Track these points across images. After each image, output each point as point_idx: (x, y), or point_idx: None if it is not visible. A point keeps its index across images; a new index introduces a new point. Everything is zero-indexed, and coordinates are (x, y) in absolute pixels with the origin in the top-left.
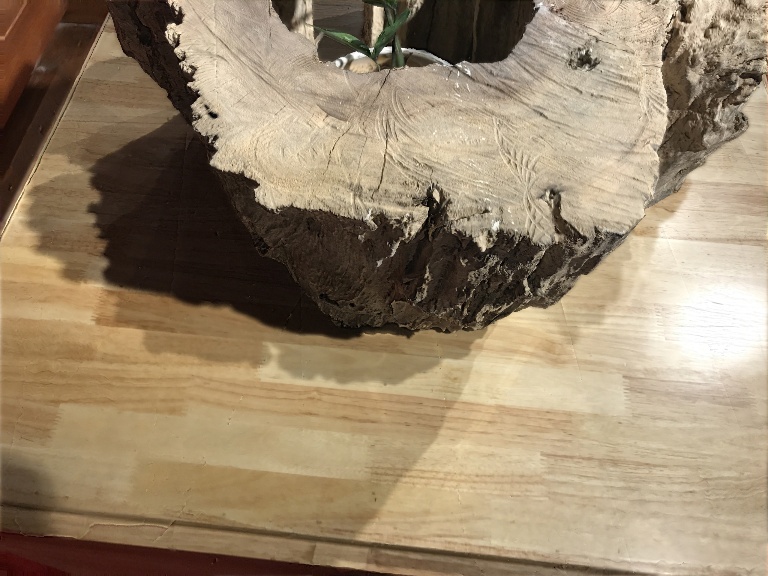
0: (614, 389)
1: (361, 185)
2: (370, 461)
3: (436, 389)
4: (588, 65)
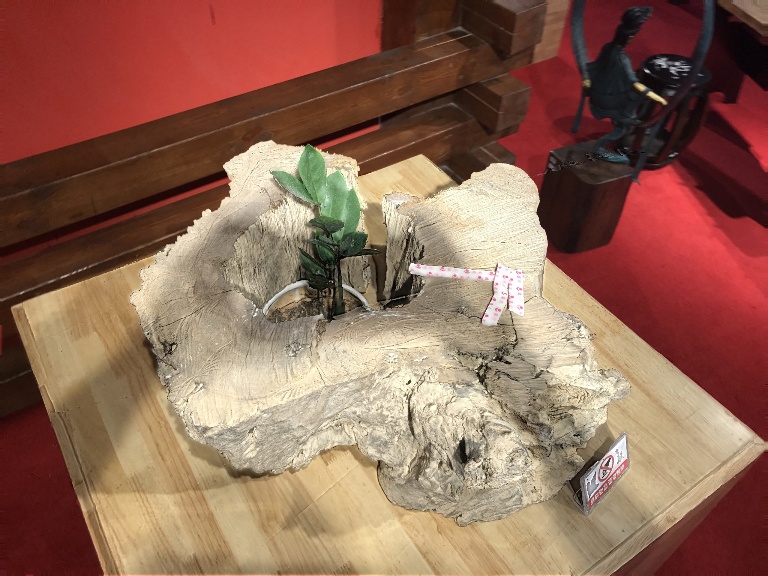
0: (265, 570)
1: (161, 320)
2: (139, 472)
3: (202, 476)
4: (294, 354)
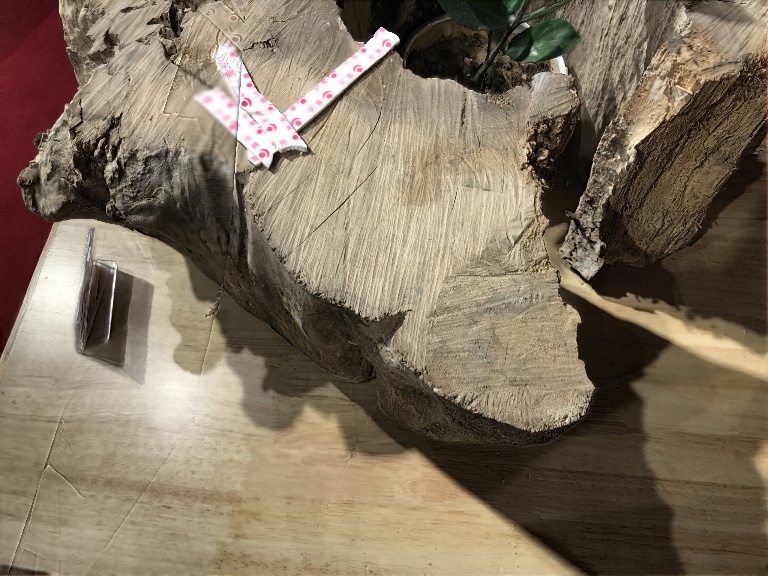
0: None
1: None
2: None
3: None
4: None
